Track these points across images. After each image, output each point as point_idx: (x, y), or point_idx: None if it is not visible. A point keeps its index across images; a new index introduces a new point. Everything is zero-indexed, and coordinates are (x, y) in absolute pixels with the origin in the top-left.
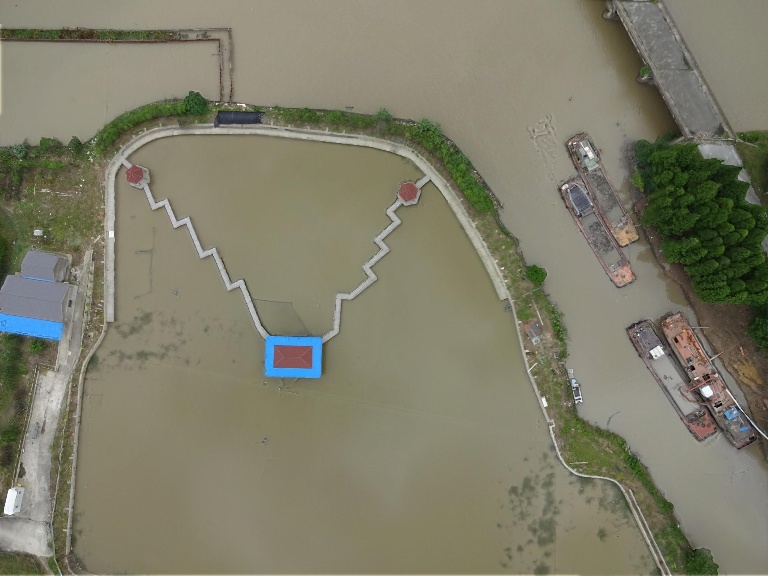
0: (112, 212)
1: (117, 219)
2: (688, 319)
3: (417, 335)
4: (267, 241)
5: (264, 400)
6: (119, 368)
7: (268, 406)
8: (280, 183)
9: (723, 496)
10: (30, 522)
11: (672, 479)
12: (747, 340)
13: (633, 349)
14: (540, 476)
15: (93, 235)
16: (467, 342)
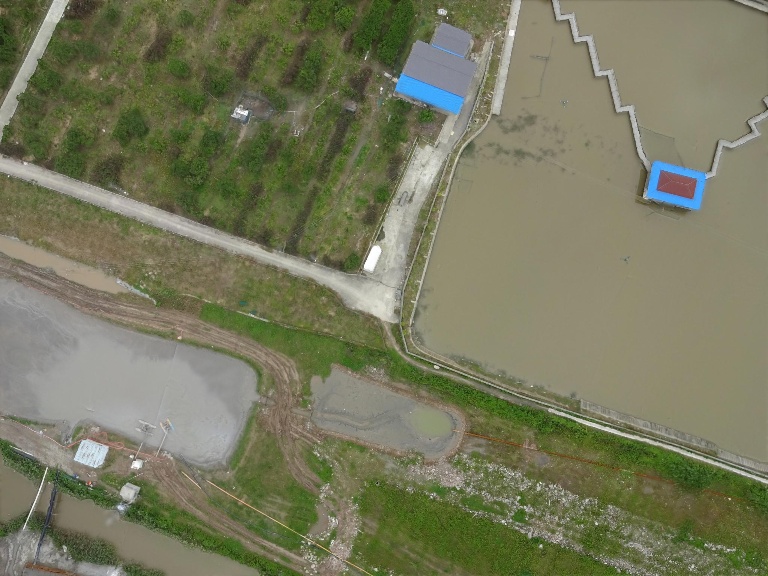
0: (516, 12)
1: (519, 20)
2: None
3: None
4: (659, 77)
5: (634, 221)
6: (494, 160)
7: (636, 228)
8: (680, 28)
9: None
10: (381, 285)
11: None
12: None
13: None
14: None
15: (494, 29)
16: None
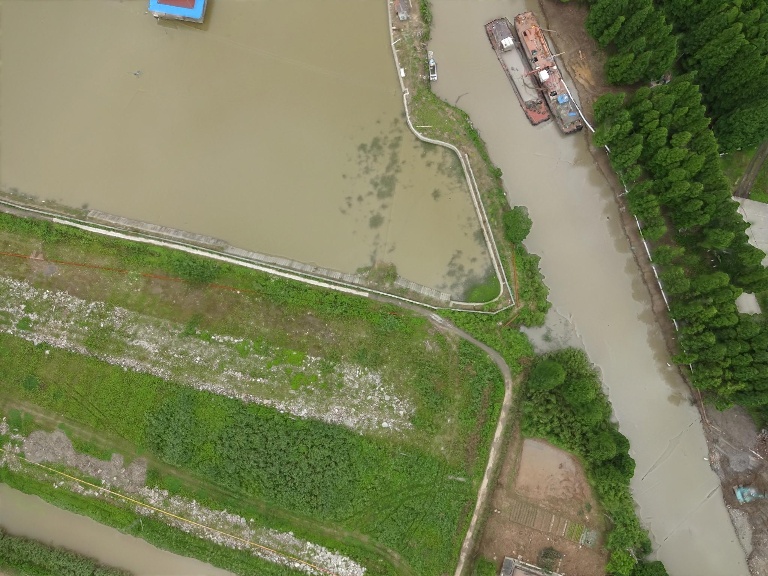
0: None
1: None
2: (538, 19)
3: (297, 2)
4: None
5: (144, 37)
6: None
7: (146, 43)
8: None
9: (549, 180)
10: None
11: (506, 160)
12: (586, 45)
13: (488, 42)
14: (389, 137)
15: None
16: (341, 12)
